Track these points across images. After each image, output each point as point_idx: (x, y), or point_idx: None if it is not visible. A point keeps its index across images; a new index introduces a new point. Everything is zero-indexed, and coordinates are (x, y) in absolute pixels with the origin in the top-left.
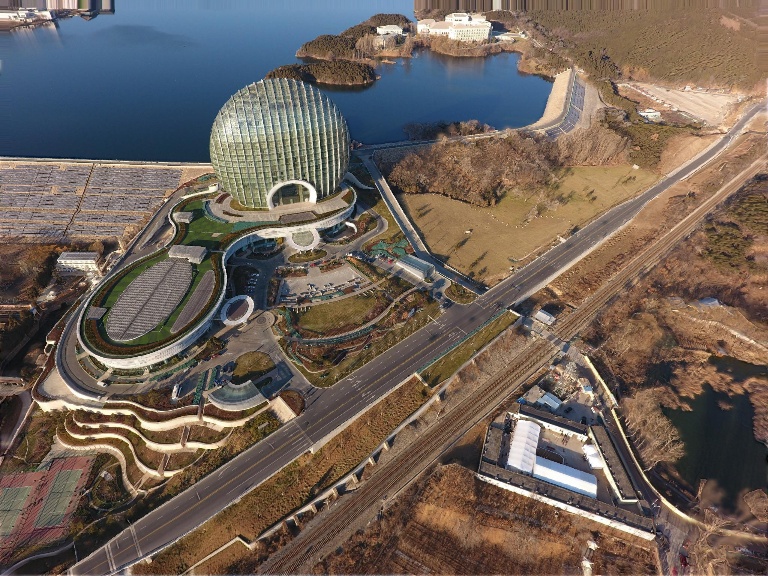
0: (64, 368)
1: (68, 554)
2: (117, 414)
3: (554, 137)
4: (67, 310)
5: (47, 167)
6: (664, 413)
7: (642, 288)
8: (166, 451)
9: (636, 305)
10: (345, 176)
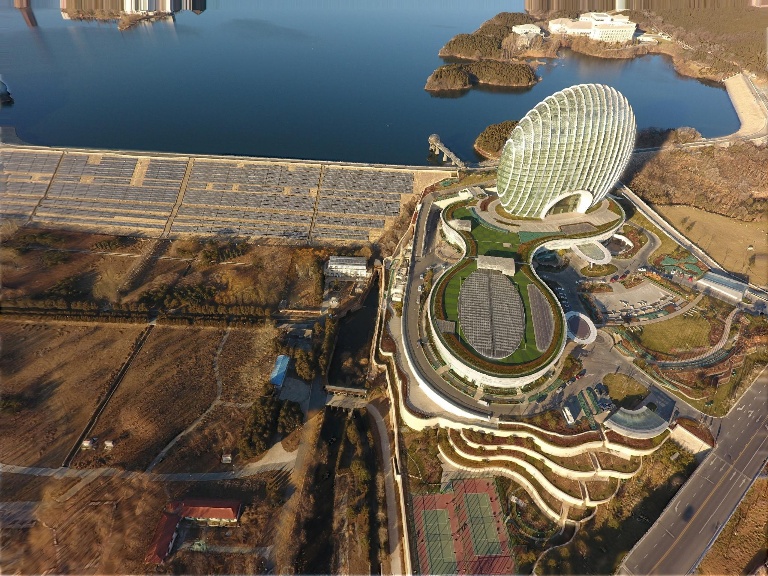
0: (431, 384)
1: None
2: (513, 436)
3: None
4: None
5: (276, 167)
6: None
7: None
8: (578, 478)
9: None
10: None
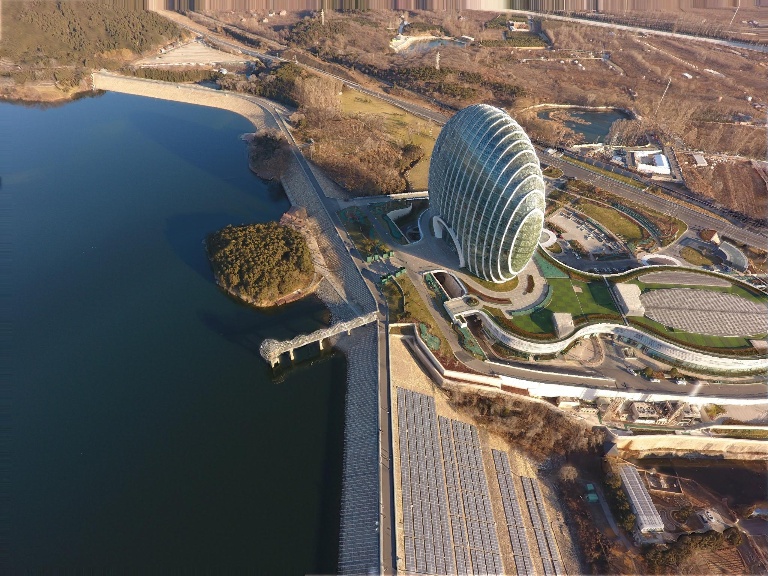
0: None
1: None
2: None
3: None
4: None
5: None
6: None
7: None
8: None
9: None
10: None
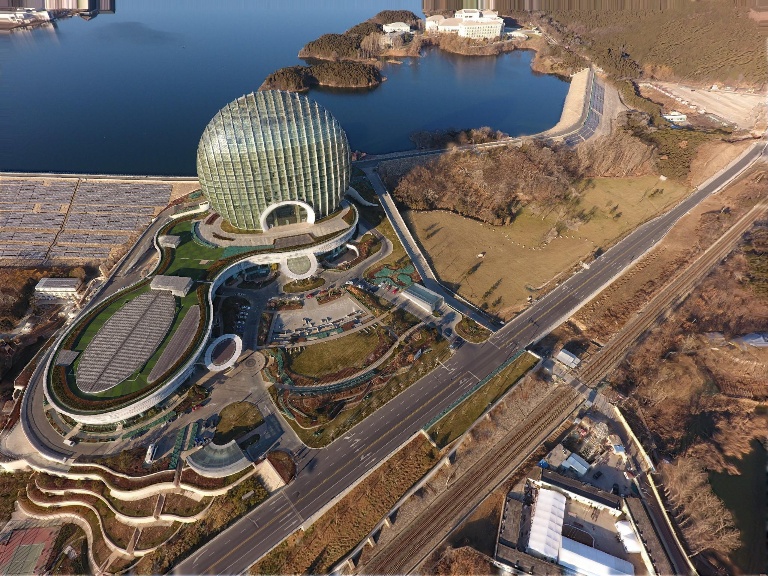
0: (29, 422)
1: None
2: (84, 479)
3: (573, 144)
4: (43, 345)
5: (30, 183)
6: (708, 477)
7: (676, 322)
8: (137, 524)
9: (670, 343)
10: (347, 191)
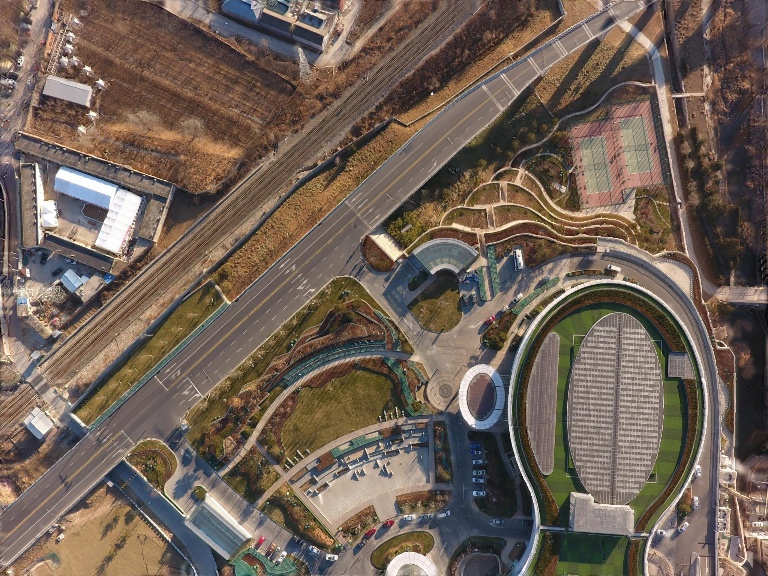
0: (675, 293)
1: (557, 115)
2: None
3: None
4: None
5: None
6: None
7: None
8: None
9: None
10: None
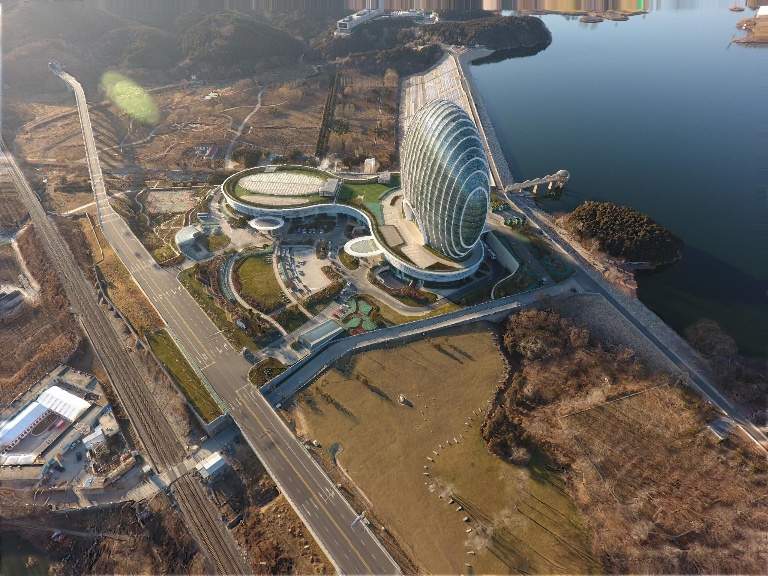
0: None
1: None
2: None
3: None
4: None
5: None
6: None
7: None
8: None
9: None
10: None
